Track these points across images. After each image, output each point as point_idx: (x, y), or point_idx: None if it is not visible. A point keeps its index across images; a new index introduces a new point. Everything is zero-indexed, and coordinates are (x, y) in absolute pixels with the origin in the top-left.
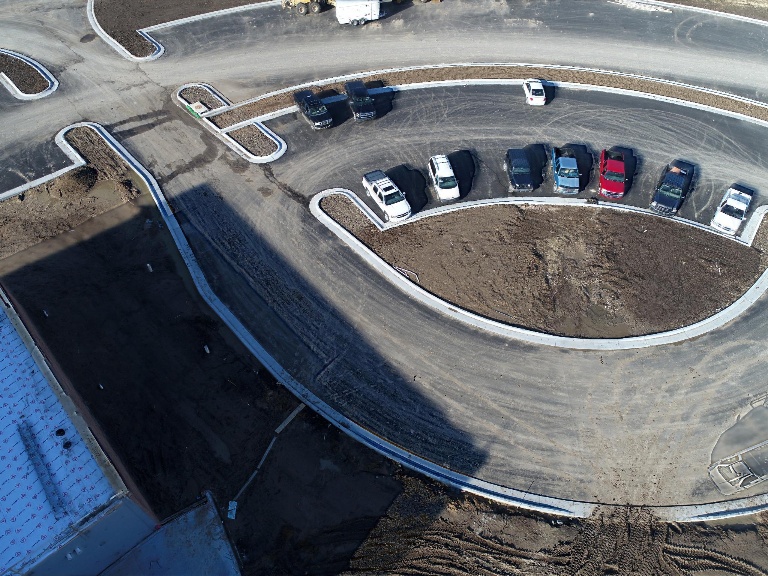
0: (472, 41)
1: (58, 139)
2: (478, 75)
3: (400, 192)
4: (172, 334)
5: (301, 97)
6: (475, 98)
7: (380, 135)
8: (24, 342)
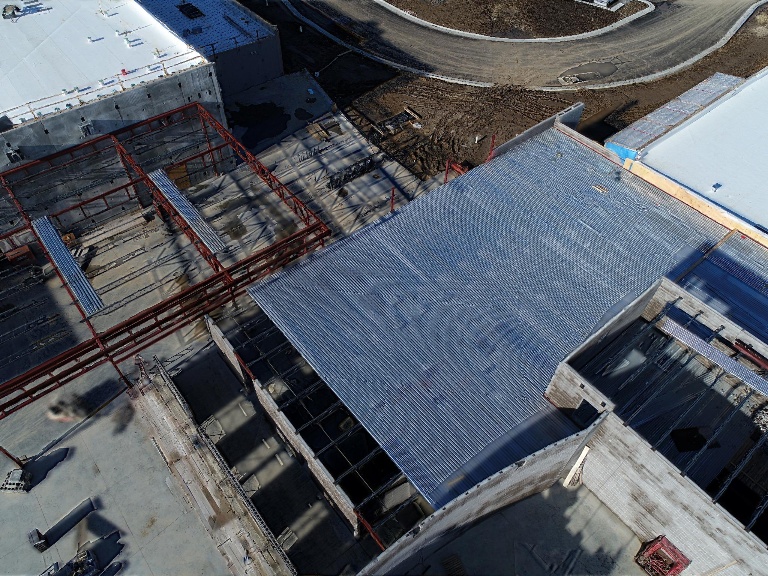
0: None
1: None
2: None
3: None
4: (281, 26)
5: None
6: None
7: None
8: None
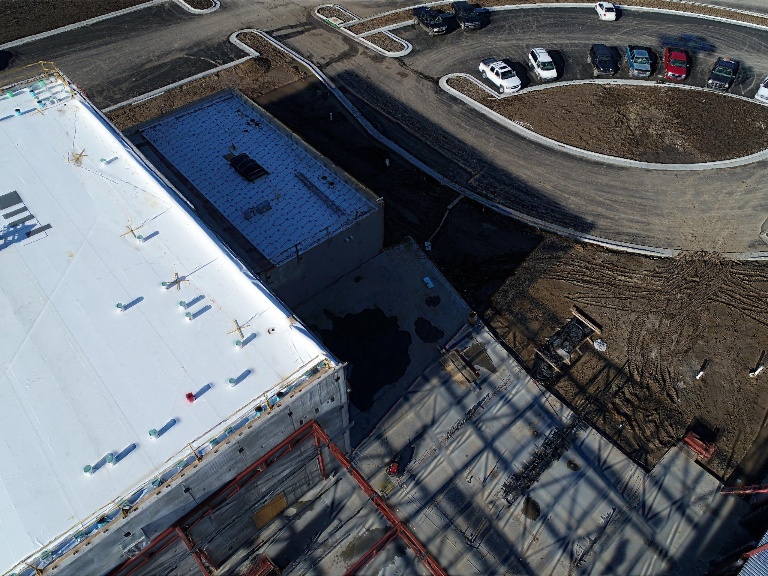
0: None
1: (232, 39)
2: (557, 0)
3: (512, 71)
4: (358, 155)
5: (419, 11)
6: (557, 16)
7: (485, 40)
8: (284, 131)
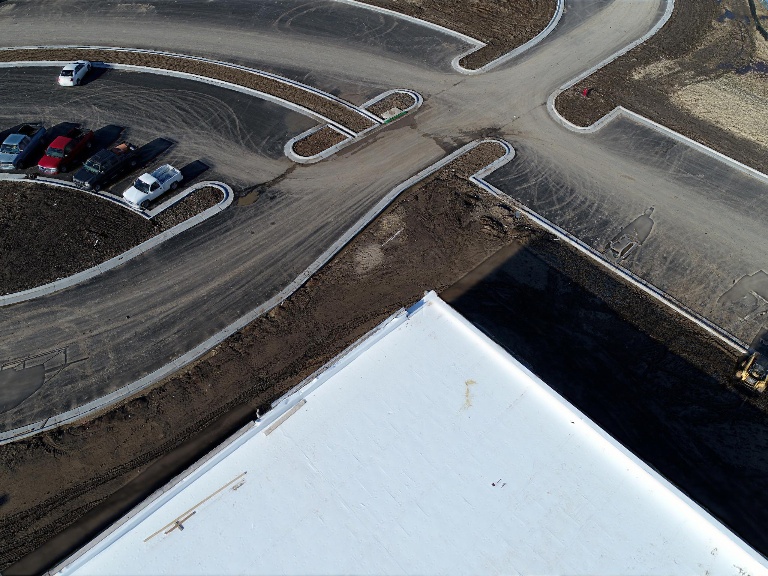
0: (66, 25)
1: None
2: (40, 57)
3: None
4: None
5: None
6: (16, 79)
7: None
8: None
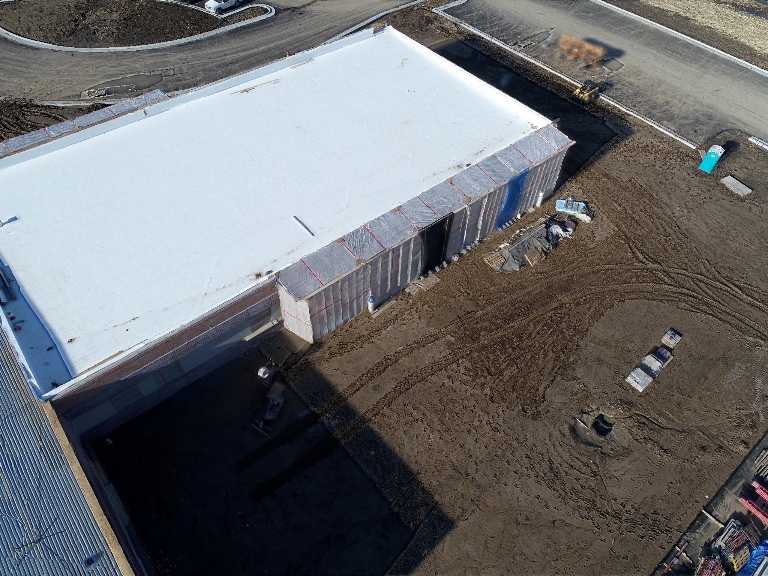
0: None
1: None
2: None
3: None
4: None
5: None
6: None
7: None
8: None
